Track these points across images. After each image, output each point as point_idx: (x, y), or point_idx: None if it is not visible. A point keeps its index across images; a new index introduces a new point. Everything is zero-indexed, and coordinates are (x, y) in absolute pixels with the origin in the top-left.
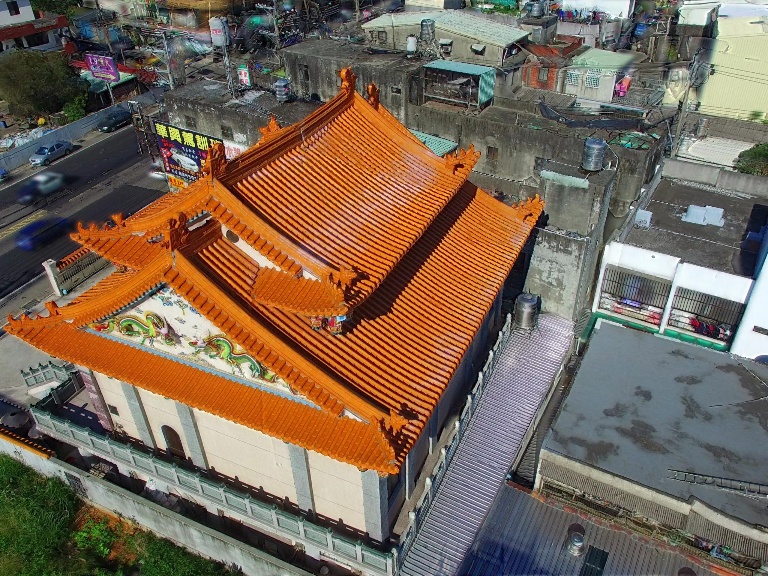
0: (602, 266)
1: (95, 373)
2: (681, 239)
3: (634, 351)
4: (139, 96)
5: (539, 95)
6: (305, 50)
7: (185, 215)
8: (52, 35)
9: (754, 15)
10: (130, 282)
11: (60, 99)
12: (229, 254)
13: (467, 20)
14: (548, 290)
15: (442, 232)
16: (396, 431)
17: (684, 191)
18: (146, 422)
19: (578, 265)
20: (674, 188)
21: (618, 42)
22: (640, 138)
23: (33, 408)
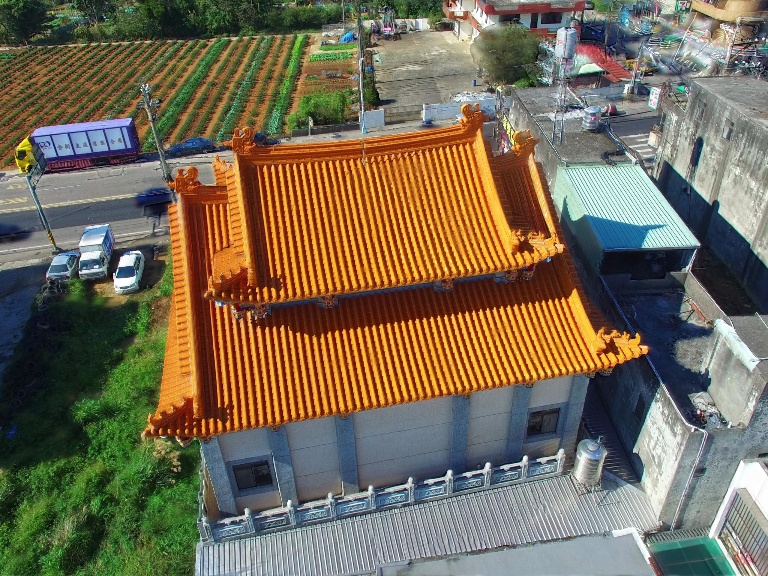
0: (731, 484)
1: None
2: None
3: None
4: (588, 90)
5: None
6: (718, 86)
7: (195, 171)
8: (565, 17)
9: None
10: None
11: (519, 74)
12: None
13: None
14: (650, 464)
15: (471, 306)
16: None
17: None
18: None
19: (677, 455)
20: None
21: None
22: None
23: None
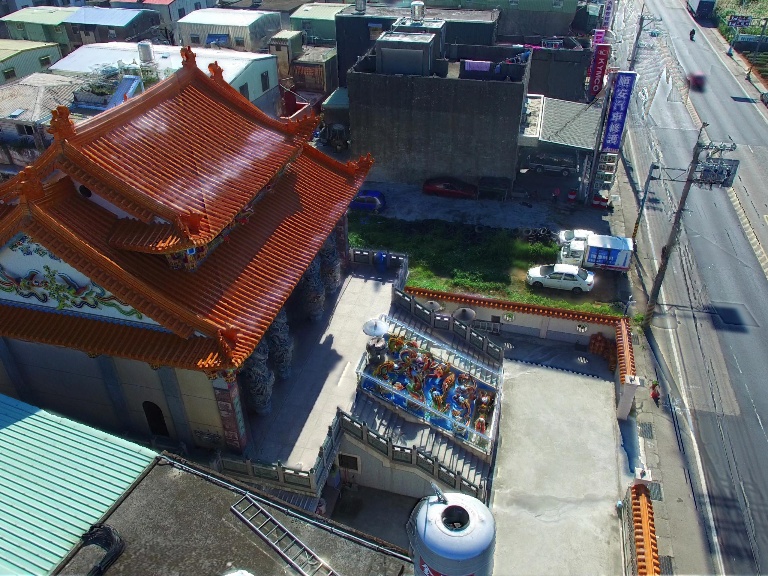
0: None
1: None
2: None
3: None
4: None
5: None
6: None
7: (209, 66)
8: None
9: None
10: None
11: None
12: None
13: None
14: None
15: None
16: None
17: None
18: None
19: None
20: None
21: None
22: None
23: None
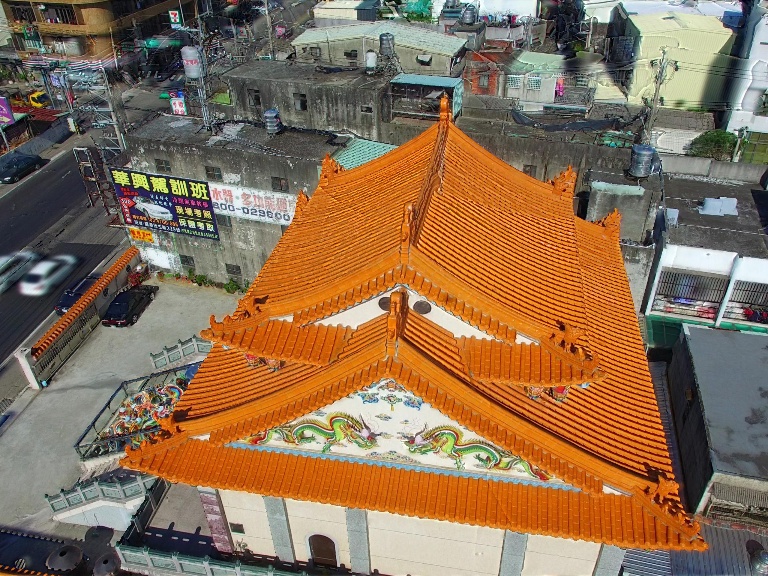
0: (658, 270)
1: (221, 491)
2: (712, 232)
3: (734, 352)
4: (36, 138)
5: (482, 101)
6: (251, 74)
7: None
8: None
9: (661, 11)
10: (313, 382)
11: None
12: (425, 329)
13: (404, 31)
14: None
15: None
16: (663, 498)
17: (684, 184)
18: (289, 535)
19: (646, 273)
20: (673, 182)
21: (544, 44)
22: (618, 136)
23: (120, 546)
